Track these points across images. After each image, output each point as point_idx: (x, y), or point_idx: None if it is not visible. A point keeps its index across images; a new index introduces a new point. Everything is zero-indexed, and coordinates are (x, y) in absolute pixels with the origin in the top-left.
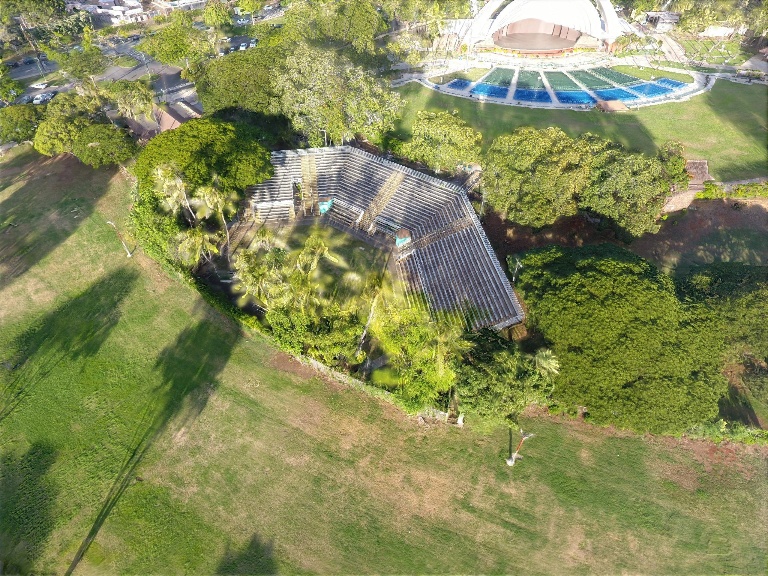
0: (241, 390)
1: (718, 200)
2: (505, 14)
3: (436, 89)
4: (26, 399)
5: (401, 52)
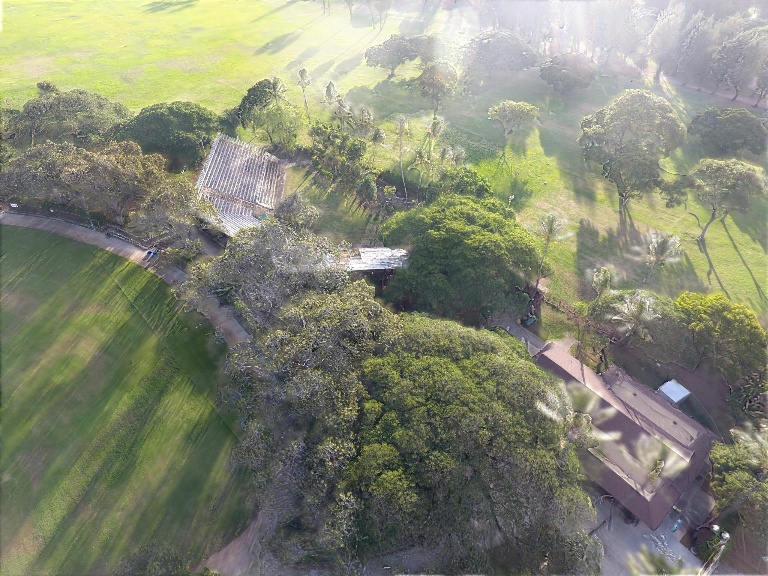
0: (382, 159)
1: None
2: None
3: None
4: (497, 162)
5: None
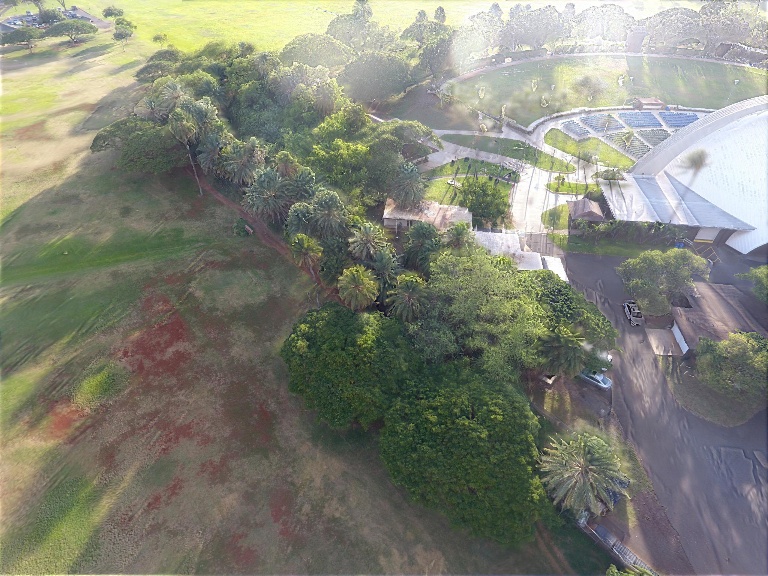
0: None
1: None
2: None
3: None
4: None
5: None
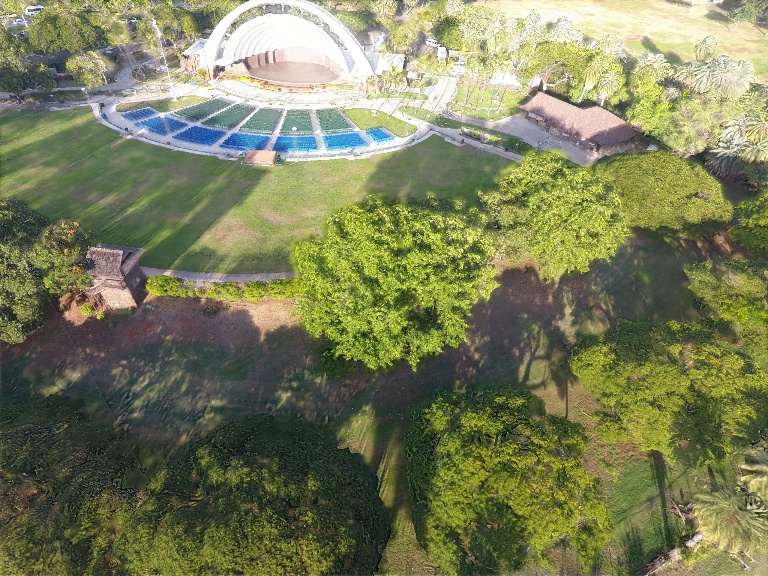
0: None
1: (193, 299)
2: (234, 39)
3: (100, 117)
4: None
5: (80, 71)
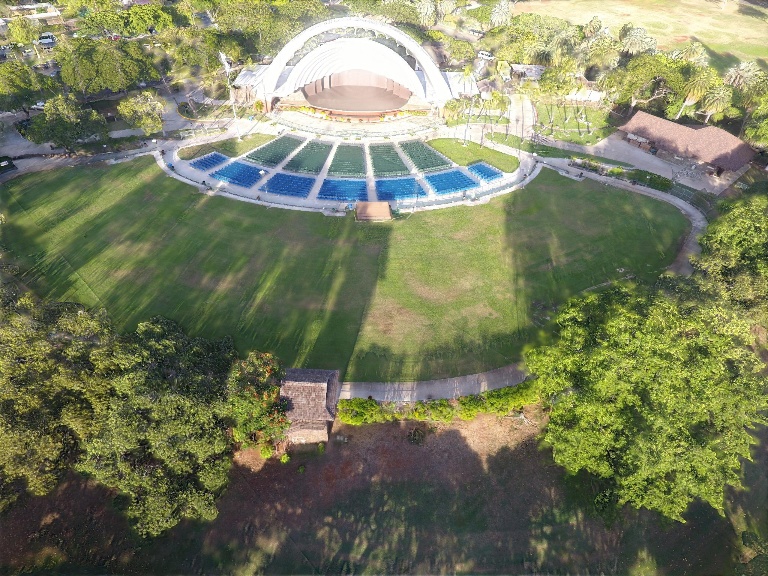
0: None
1: (390, 422)
2: (298, 67)
3: (168, 169)
4: None
5: (135, 115)
